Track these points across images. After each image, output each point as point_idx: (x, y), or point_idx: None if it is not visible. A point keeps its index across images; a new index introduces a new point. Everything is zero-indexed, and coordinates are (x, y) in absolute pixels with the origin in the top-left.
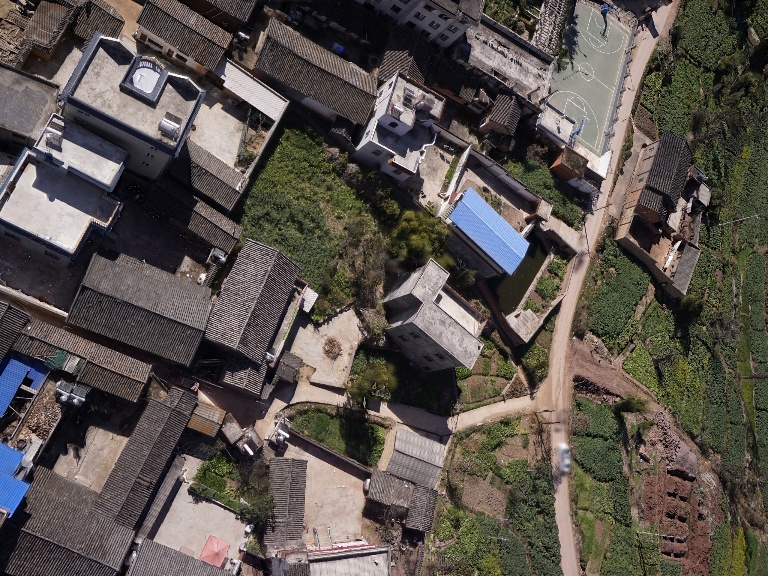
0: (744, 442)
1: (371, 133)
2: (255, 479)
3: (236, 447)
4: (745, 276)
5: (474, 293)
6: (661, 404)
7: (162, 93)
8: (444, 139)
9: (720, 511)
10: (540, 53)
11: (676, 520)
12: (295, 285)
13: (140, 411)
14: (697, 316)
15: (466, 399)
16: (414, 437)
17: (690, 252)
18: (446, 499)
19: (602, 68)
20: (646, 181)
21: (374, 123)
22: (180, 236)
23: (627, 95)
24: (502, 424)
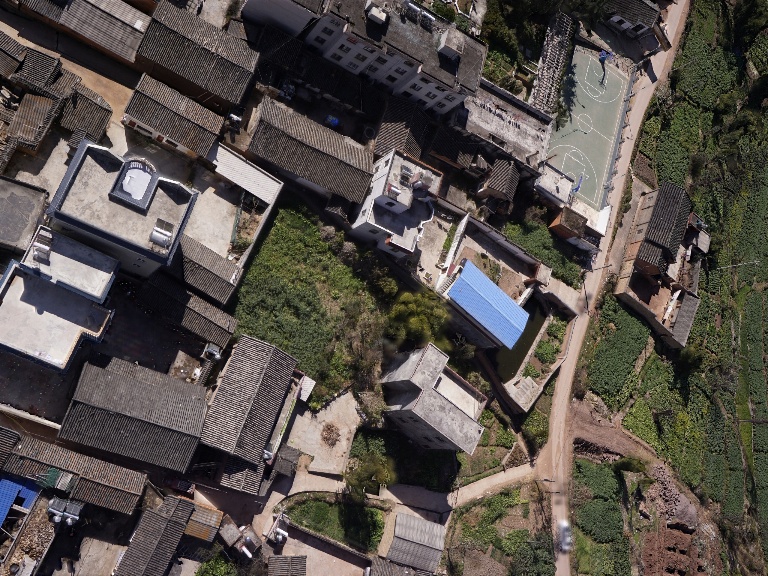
0: (743, 488)
1: (368, 213)
2: None
3: (234, 547)
4: (744, 316)
5: (473, 364)
6: (661, 458)
7: (153, 199)
8: (441, 207)
9: (719, 560)
10: (538, 113)
11: (676, 574)
12: (292, 376)
13: (135, 517)
14: (697, 367)
15: (466, 472)
16: (414, 520)
17: (689, 301)
18: None
19: (601, 118)
20: (645, 234)
21: (370, 203)
22: (173, 330)
23: (626, 145)
24: (502, 495)
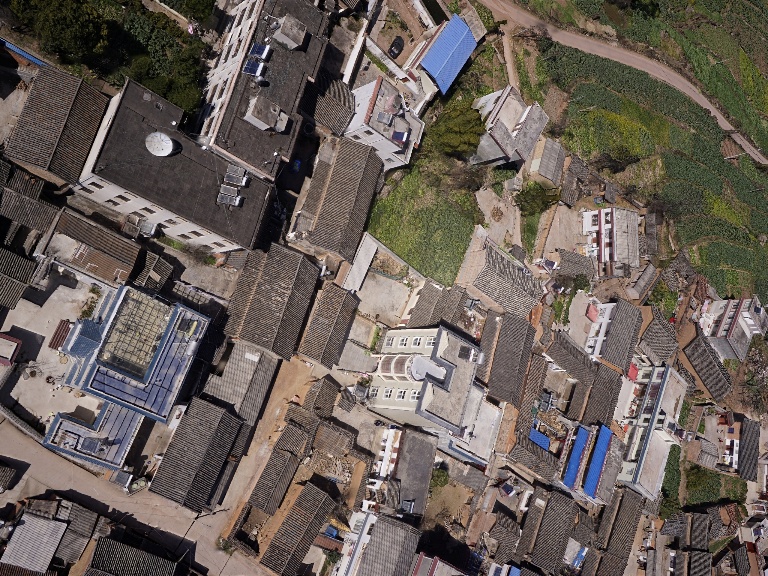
0: None
1: None
2: None
3: None
4: None
5: None
6: None
7: None
8: None
9: None
10: None
11: None
12: None
13: None
14: None
15: None
16: (543, 161)
17: None
18: (560, 140)
19: None
20: None
21: None
22: None
23: None
24: None
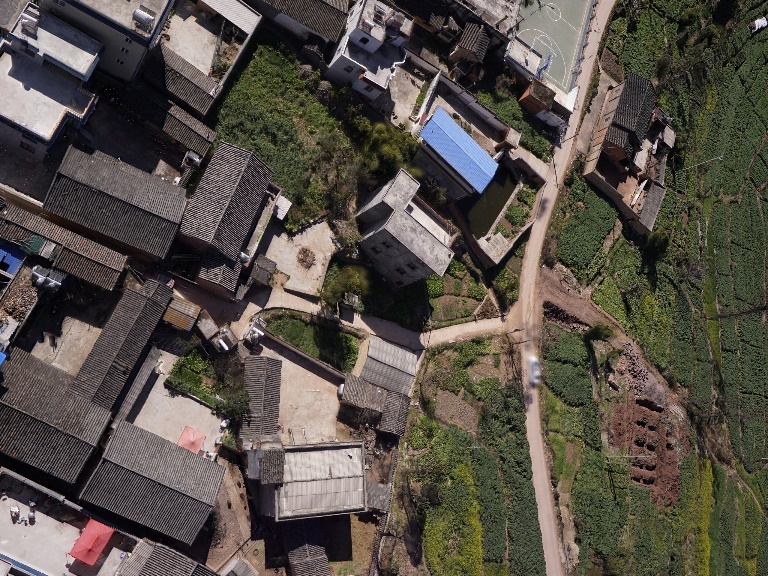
0: (711, 379)
1: (342, 48)
2: (230, 378)
3: (211, 345)
4: (710, 222)
5: (445, 214)
6: (629, 336)
7: None
8: (415, 65)
9: (688, 443)
10: None
11: (645, 449)
12: (269, 191)
13: (116, 305)
14: (663, 251)
15: (438, 317)
16: (387, 346)
17: (656, 191)
18: (419, 410)
19: (569, 10)
20: (612, 118)
21: (345, 39)
22: (155, 140)
23: (593, 37)
24: (474, 343)
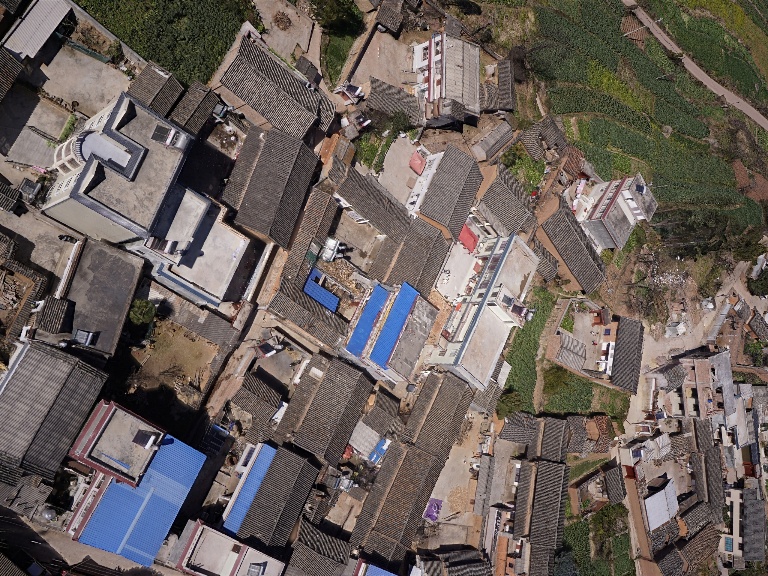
0: None
1: None
2: None
3: None
4: None
5: None
6: None
7: None
8: None
9: None
10: None
11: None
12: None
13: None
14: None
15: None
16: None
17: None
18: None
19: None
20: None
21: None
22: None
23: None
24: None
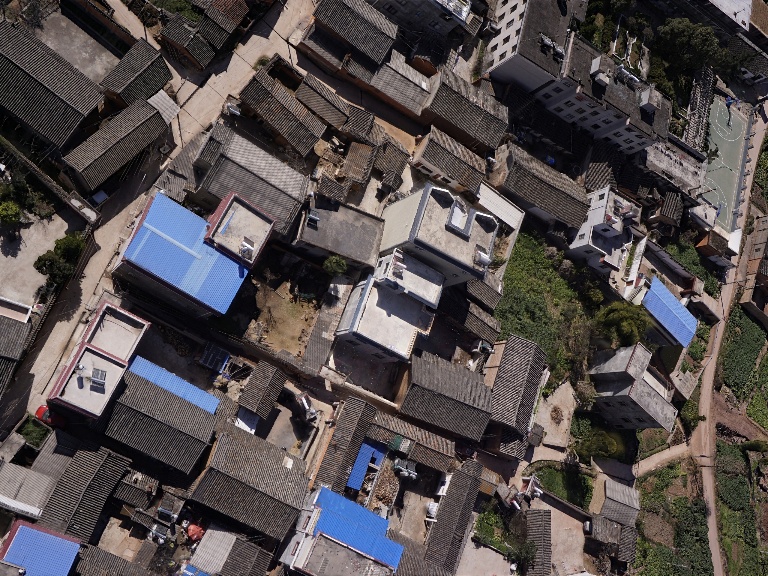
0: None
1: (588, 237)
2: (513, 526)
3: (501, 501)
4: None
5: None
6: None
7: (472, 229)
8: None
9: None
10: (696, 153)
11: None
12: None
13: (436, 476)
14: None
15: (643, 449)
16: (617, 485)
17: None
18: None
19: (728, 154)
20: (765, 252)
21: (590, 229)
22: (452, 330)
23: (747, 176)
24: (669, 468)
